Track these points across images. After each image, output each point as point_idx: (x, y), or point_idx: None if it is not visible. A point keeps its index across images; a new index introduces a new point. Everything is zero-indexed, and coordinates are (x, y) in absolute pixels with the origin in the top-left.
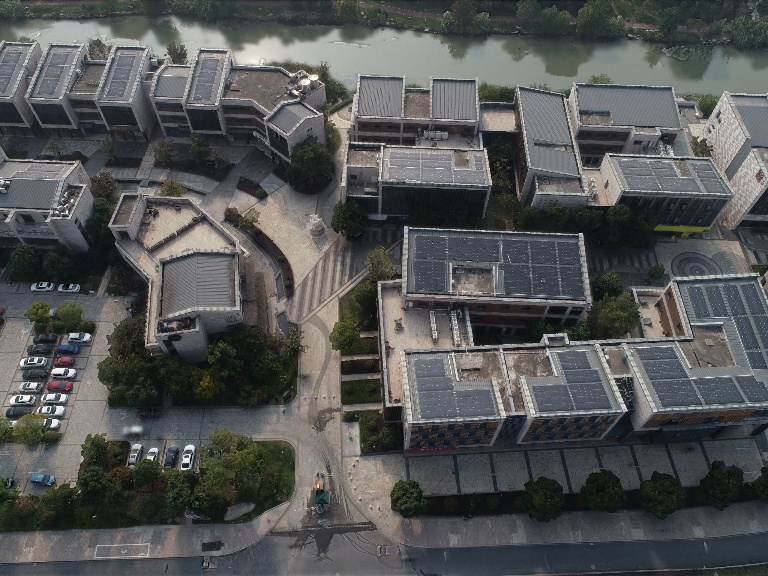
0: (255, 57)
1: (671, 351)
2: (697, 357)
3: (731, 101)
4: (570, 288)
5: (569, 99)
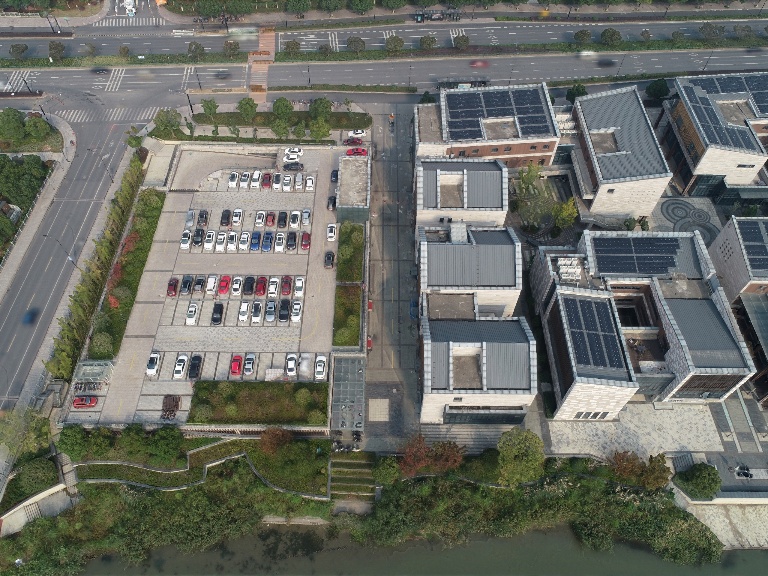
0: None
1: (762, 110)
2: (741, 110)
3: (747, 351)
4: None
5: None
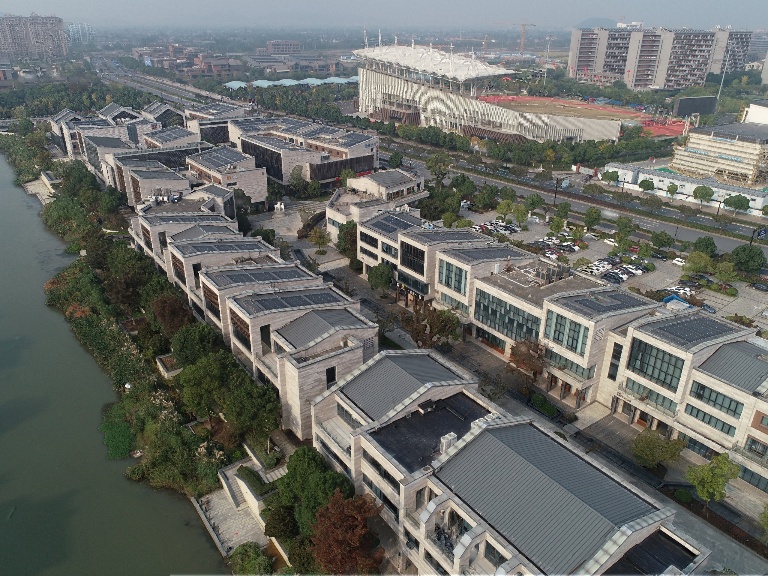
0: (27, 327)
1: None
2: None
3: (91, 129)
4: (272, 138)
5: (102, 158)
